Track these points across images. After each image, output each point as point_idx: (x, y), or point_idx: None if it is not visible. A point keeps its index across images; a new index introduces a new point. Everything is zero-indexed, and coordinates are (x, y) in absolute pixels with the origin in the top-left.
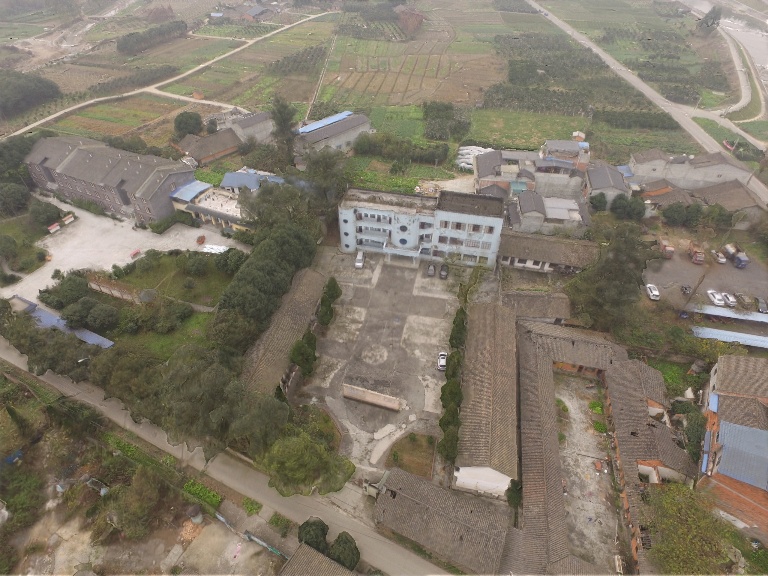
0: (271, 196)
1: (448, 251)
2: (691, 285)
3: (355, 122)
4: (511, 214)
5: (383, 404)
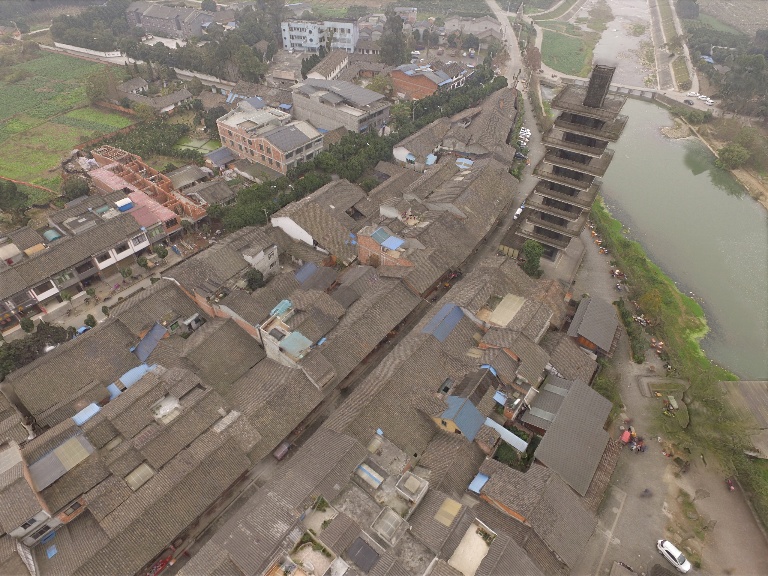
0: (249, 14)
1: (333, 46)
2: (443, 61)
3: (302, 6)
4: (369, 36)
5: (288, 78)
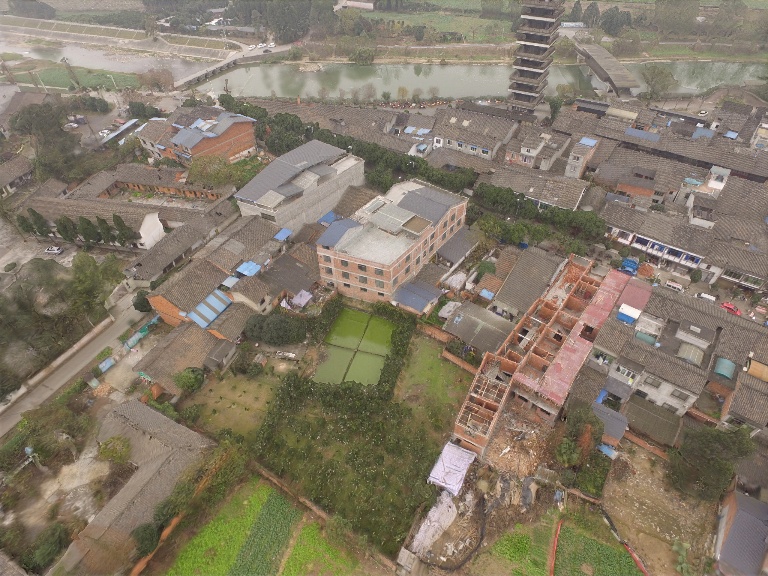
0: None
1: None
2: None
3: None
4: None
5: None
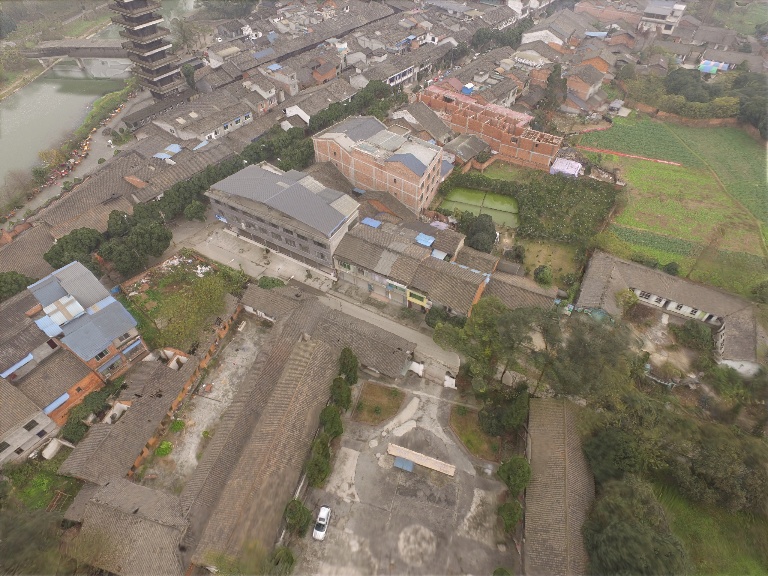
0: None
1: None
2: None
3: None
4: None
5: None
